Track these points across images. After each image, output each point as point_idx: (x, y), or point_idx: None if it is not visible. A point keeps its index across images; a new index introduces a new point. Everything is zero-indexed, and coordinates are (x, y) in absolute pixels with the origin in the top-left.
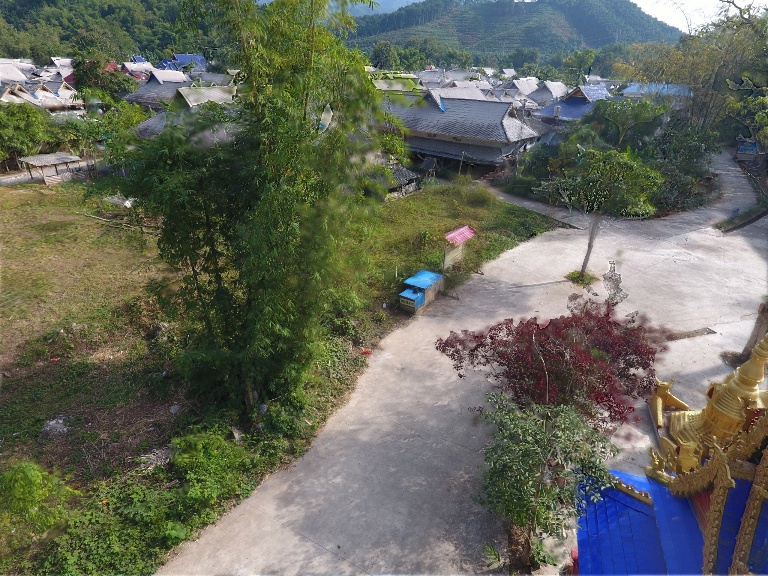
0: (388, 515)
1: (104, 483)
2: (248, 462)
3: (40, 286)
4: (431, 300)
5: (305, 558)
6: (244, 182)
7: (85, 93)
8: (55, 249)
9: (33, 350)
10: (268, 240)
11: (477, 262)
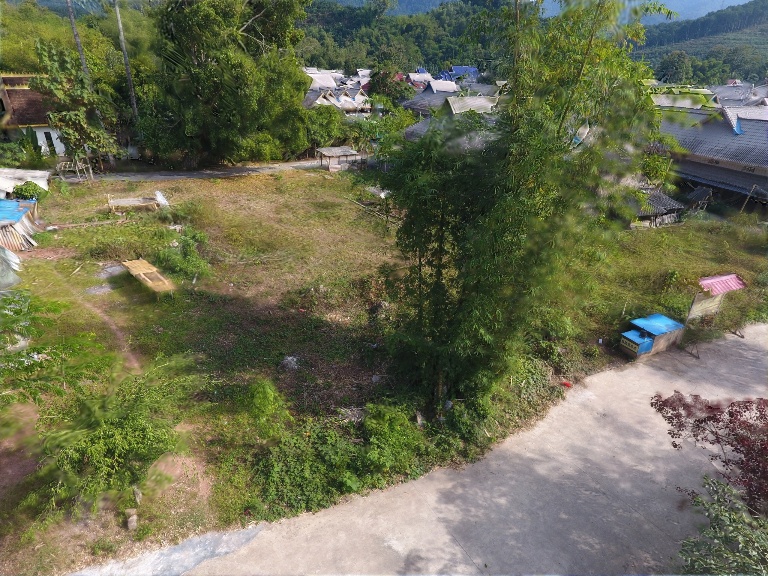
0: (546, 560)
1: (311, 419)
2: (423, 448)
3: (307, 251)
4: (661, 350)
5: (451, 559)
6: (483, 188)
7: (374, 99)
8: (323, 223)
9: (291, 299)
10: (491, 246)
11: (738, 321)
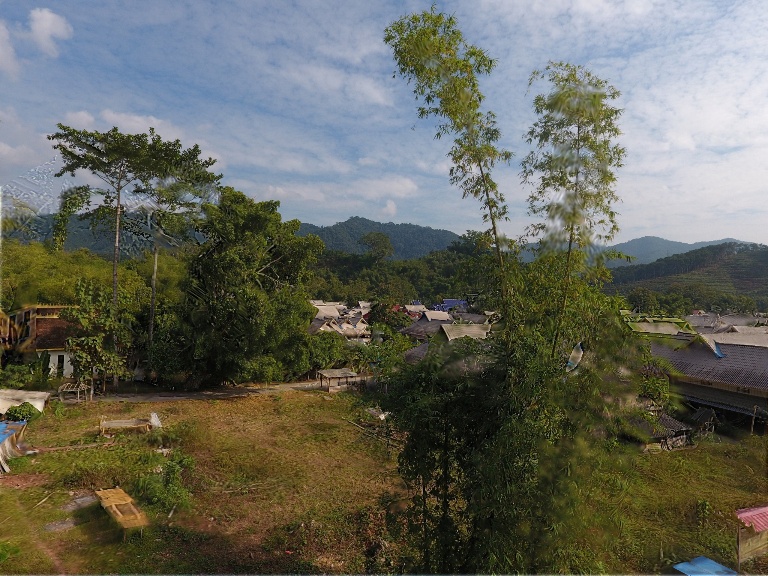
0: None
1: None
2: None
3: (300, 477)
4: None
5: None
6: (486, 410)
7: (374, 326)
8: (319, 447)
9: (277, 537)
10: (502, 474)
11: None
